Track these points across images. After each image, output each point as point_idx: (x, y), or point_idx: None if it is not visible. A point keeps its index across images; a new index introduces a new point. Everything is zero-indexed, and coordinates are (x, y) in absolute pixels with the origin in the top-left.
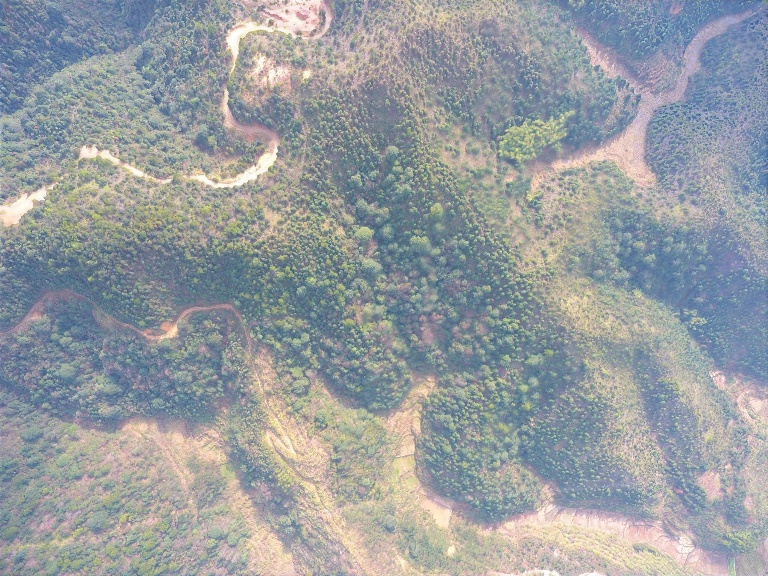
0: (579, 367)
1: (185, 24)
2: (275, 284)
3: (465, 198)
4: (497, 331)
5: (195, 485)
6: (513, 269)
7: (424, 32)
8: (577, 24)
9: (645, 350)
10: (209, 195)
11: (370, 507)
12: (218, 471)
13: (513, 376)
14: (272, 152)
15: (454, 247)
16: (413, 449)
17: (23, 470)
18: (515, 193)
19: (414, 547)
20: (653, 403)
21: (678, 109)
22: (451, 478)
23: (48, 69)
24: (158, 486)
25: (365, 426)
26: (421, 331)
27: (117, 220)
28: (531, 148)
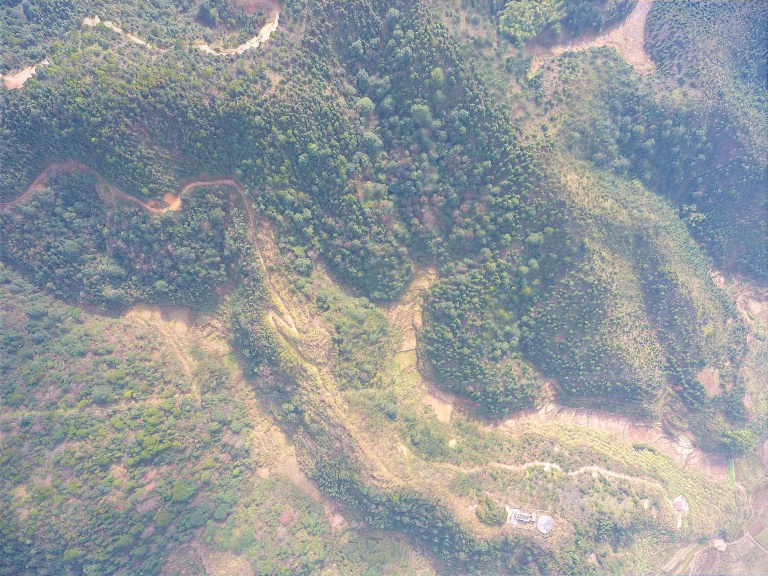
0: (579, 247)
1: None
2: (277, 149)
3: (465, 64)
4: (497, 209)
5: (198, 370)
6: (513, 142)
7: None
8: None
9: (644, 236)
10: (211, 61)
11: (372, 393)
12: (221, 361)
13: (513, 256)
14: (273, 22)
15: (455, 118)
16: (414, 344)
17: (28, 345)
18: (515, 70)
19: (416, 434)
20: (653, 296)
21: None
22: (452, 368)
23: None
24: (162, 369)
25: (367, 313)
26: (422, 214)
27: (120, 78)
28: (531, 25)
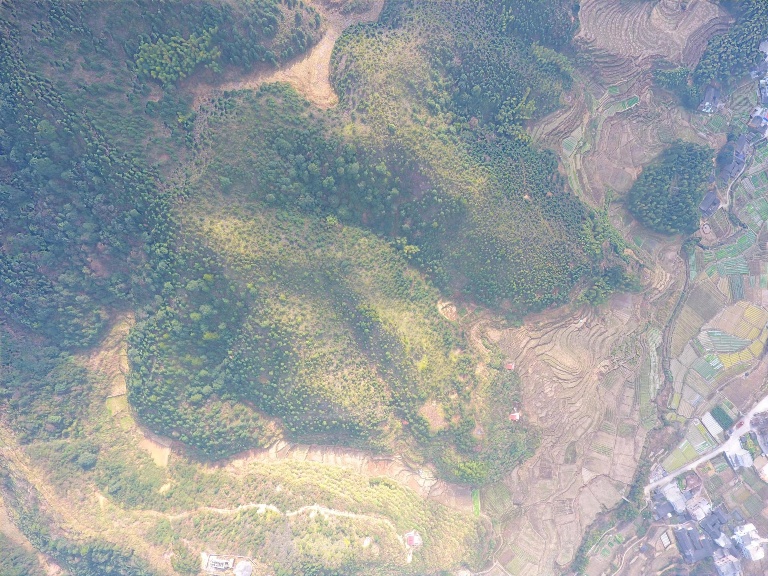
0: (247, 292)
1: None
2: None
3: (77, 115)
4: (155, 257)
5: None
6: (152, 190)
7: None
8: None
9: (331, 276)
10: None
11: (59, 444)
12: None
13: (178, 303)
14: None
15: (83, 169)
16: (125, 388)
17: None
18: (160, 114)
19: (112, 483)
20: (361, 332)
21: (362, 28)
22: (151, 414)
23: None
24: None
25: (52, 363)
26: (89, 262)
27: None
28: (175, 67)
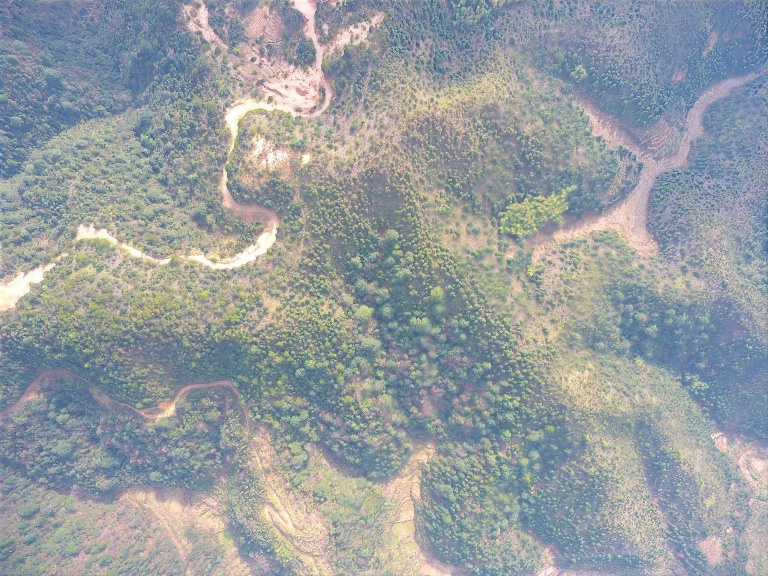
0: (580, 441)
1: (184, 95)
2: (274, 368)
3: (466, 280)
4: (497, 406)
5: (193, 556)
6: (514, 348)
7: (425, 120)
8: (579, 94)
9: (646, 421)
10: (207, 278)
11: None
12: (216, 539)
13: (513, 451)
14: (271, 232)
15: (454, 327)
16: (412, 514)
17: (19, 548)
18: (516, 269)
19: None
20: (654, 470)
21: (680, 176)
22: (451, 547)
23: (46, 133)
24: (155, 559)
25: (364, 496)
26: (421, 404)
27: (114, 308)
28: (532, 223)
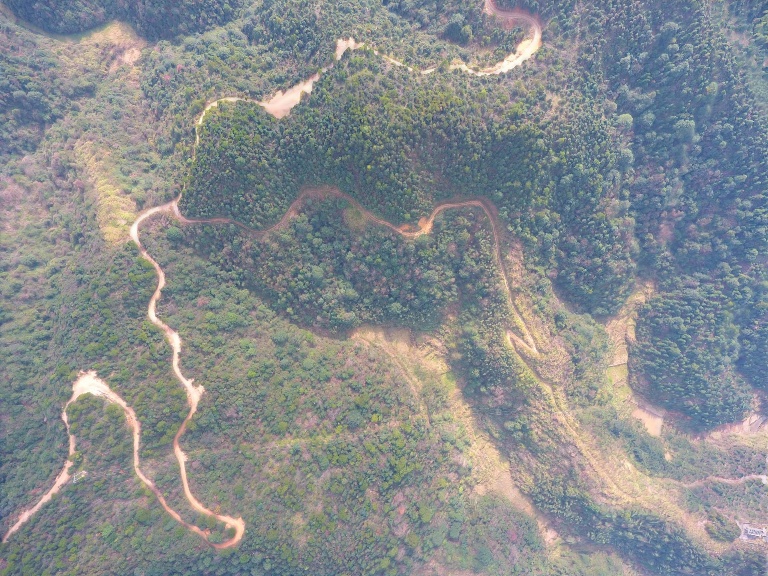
0: None
1: None
2: (547, 170)
3: (738, 77)
4: (745, 224)
5: (426, 391)
6: None
7: None
8: None
9: None
10: (478, 81)
11: (600, 410)
12: (440, 380)
13: (758, 270)
14: (533, 38)
15: (717, 132)
16: (626, 358)
17: (277, 371)
18: None
19: (640, 450)
20: None
21: None
22: (674, 383)
23: None
24: (394, 391)
25: None
26: (659, 229)
27: (401, 104)
28: None
